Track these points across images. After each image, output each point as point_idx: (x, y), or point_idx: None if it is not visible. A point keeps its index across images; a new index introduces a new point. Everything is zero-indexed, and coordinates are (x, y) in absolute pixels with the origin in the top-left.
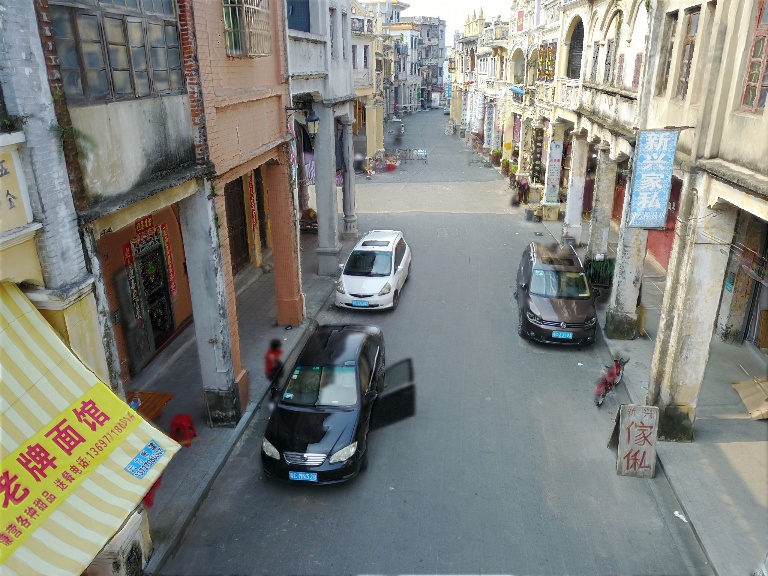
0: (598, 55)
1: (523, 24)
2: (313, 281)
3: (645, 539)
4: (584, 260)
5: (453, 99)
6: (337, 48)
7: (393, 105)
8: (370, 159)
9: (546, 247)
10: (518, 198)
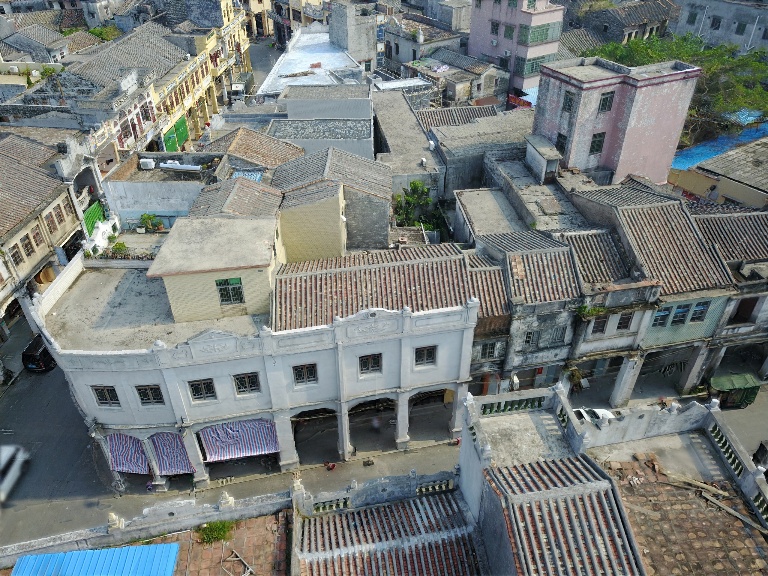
0: None
1: None
2: None
3: None
4: (6, 375)
5: None
6: None
7: None
8: None
9: None
10: None
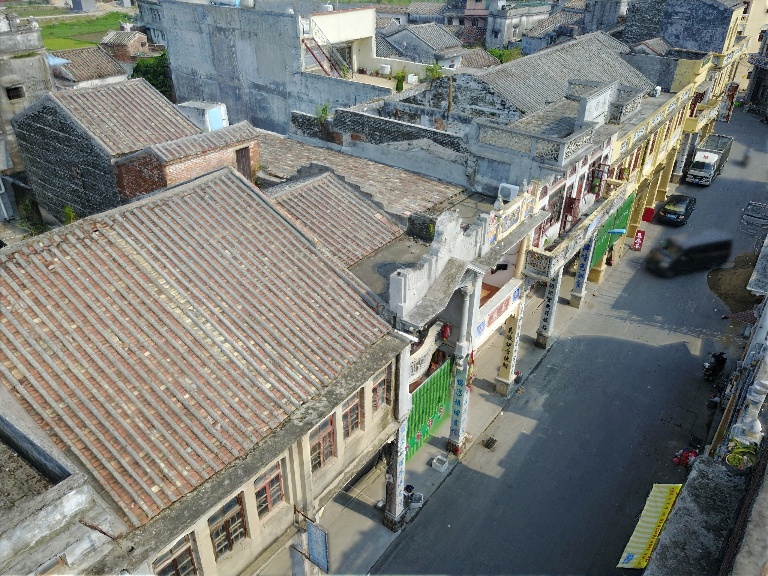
0: None
1: None
2: None
3: (396, 575)
4: None
5: None
6: None
7: None
8: None
9: None
10: None
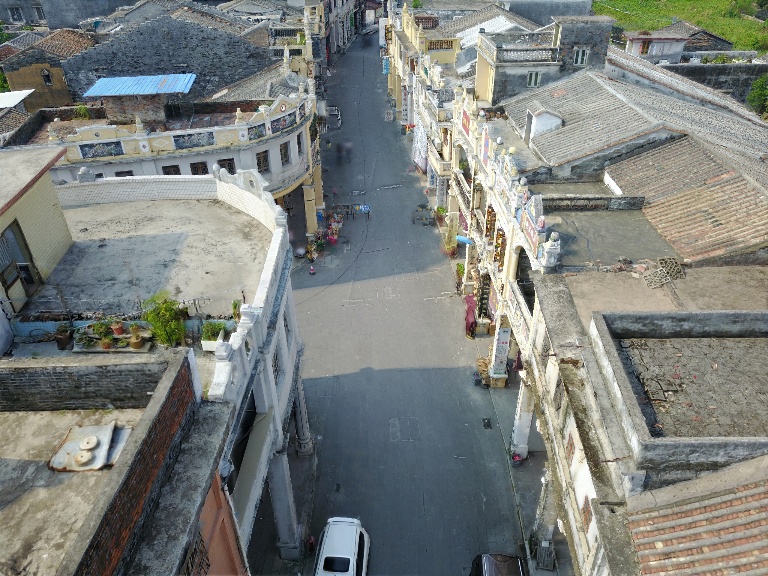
0: (549, 356)
1: (469, 134)
2: (277, 575)
3: None
4: (531, 536)
5: (391, 67)
6: (282, 363)
7: (325, 58)
8: (312, 244)
9: (495, 460)
10: (465, 322)
